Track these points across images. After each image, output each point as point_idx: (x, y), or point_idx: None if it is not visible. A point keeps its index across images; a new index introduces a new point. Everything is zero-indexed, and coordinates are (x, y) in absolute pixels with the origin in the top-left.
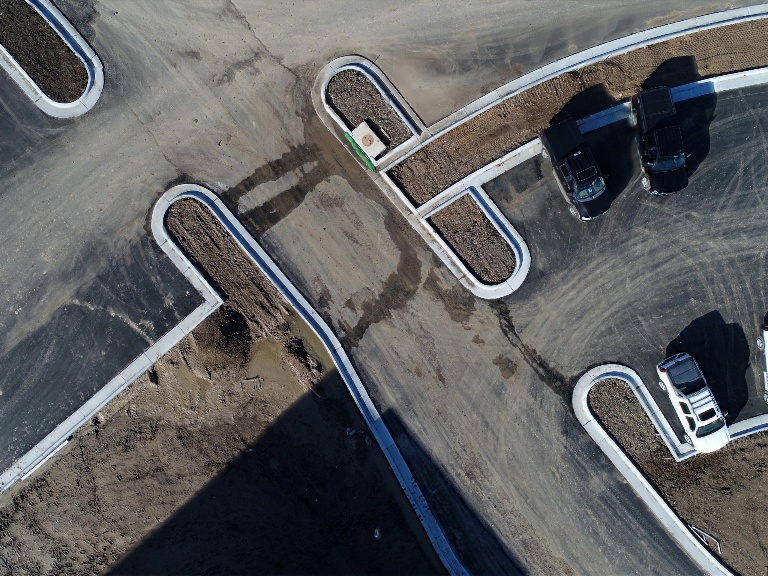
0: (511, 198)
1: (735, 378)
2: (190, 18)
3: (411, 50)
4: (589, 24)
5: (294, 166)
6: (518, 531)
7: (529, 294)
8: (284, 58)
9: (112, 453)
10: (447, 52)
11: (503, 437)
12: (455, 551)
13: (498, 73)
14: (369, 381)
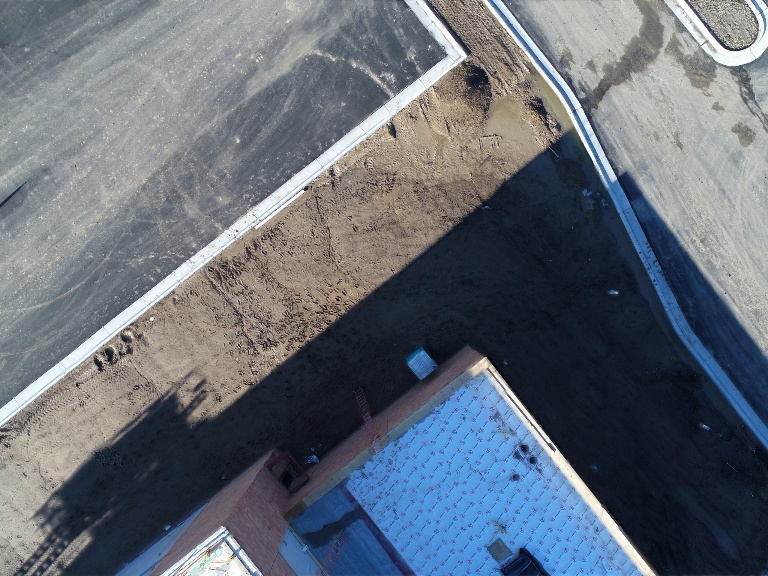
0: None
1: None
2: None
3: None
4: None
5: None
6: (752, 301)
7: None
8: None
9: (348, 204)
10: None
11: (740, 205)
12: (687, 319)
13: None
14: (607, 143)
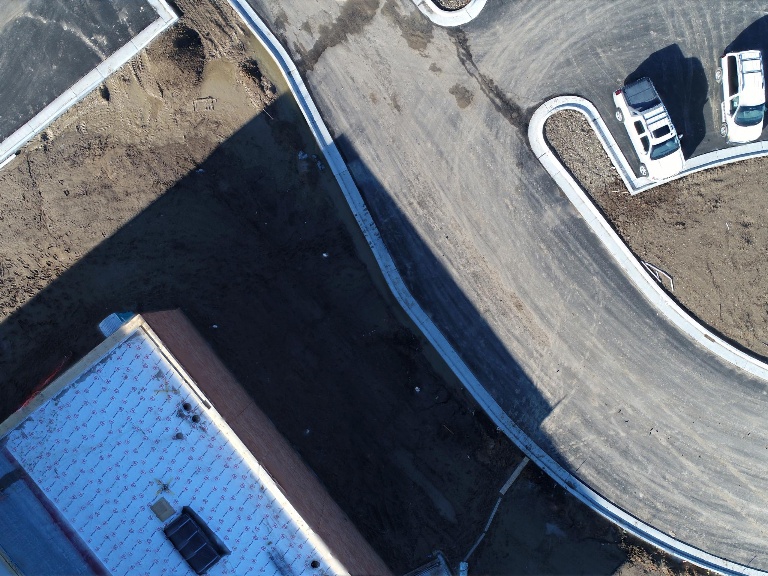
0: None
1: (693, 113)
2: None
3: None
4: None
5: None
6: (470, 263)
7: (487, 23)
8: None
9: (60, 168)
10: None
11: (457, 167)
12: (405, 281)
13: None
14: (323, 105)
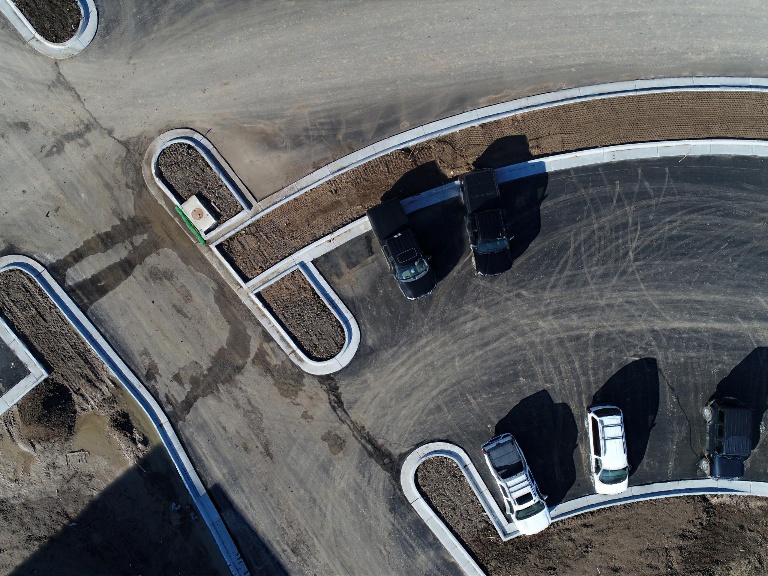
0: (341, 274)
1: (563, 458)
2: (18, 88)
3: (242, 124)
4: (421, 102)
5: (123, 238)
6: None
7: (358, 370)
8: (114, 130)
9: None
10: (278, 127)
11: (331, 514)
12: None
13: (329, 149)
14: (196, 456)
